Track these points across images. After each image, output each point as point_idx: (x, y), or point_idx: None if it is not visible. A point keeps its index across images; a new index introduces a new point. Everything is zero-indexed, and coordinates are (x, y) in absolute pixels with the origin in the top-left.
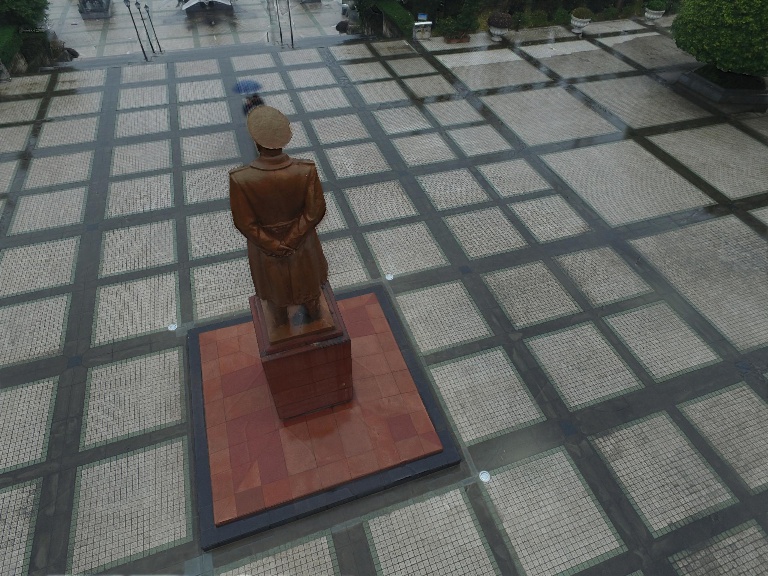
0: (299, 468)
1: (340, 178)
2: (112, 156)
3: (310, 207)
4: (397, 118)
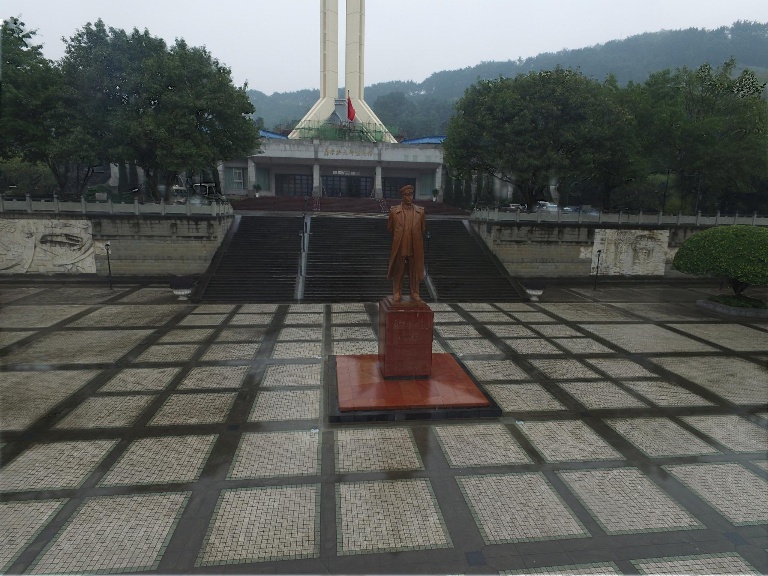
0: None
1: None
2: None
3: None
4: None
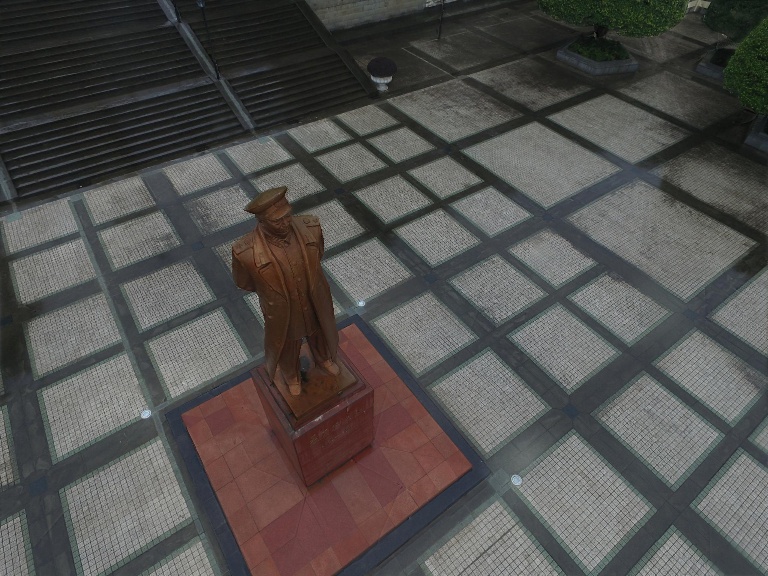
0: None
1: None
2: None
3: None
4: None
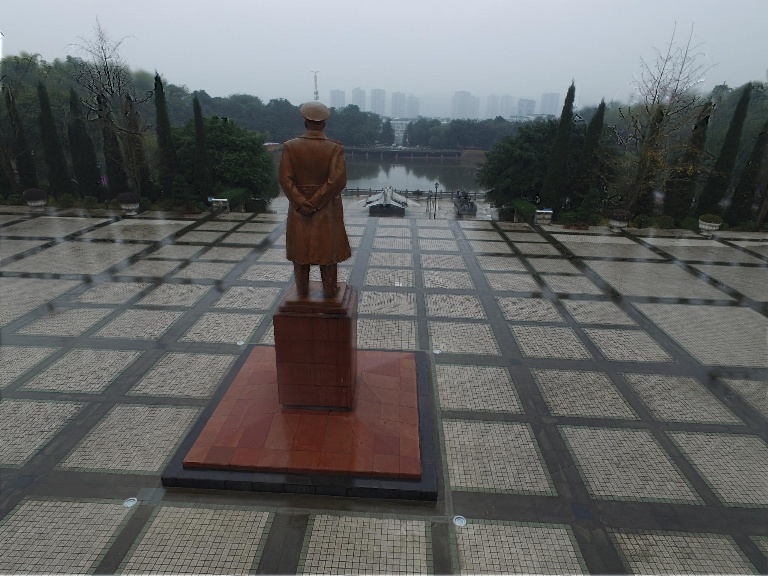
0: (275, 445)
1: (426, 287)
2: (264, 252)
3: (331, 172)
4: (496, 262)
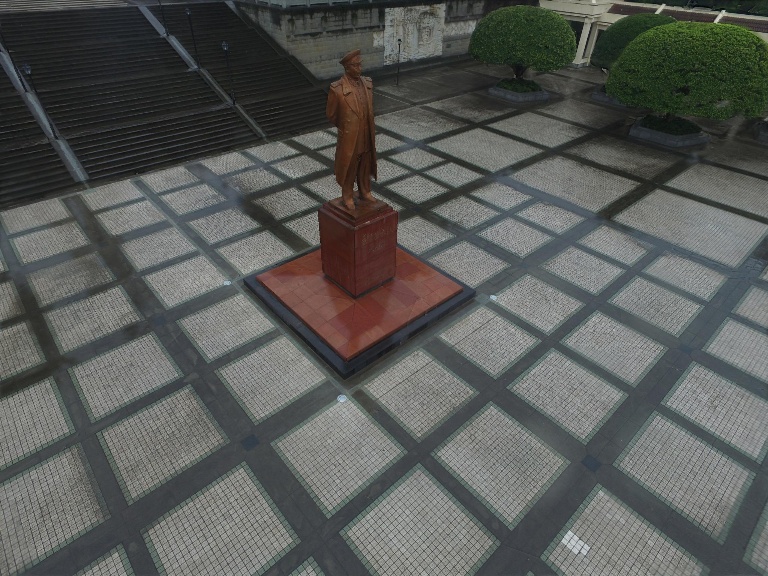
0: None
1: None
2: None
3: None
4: None
